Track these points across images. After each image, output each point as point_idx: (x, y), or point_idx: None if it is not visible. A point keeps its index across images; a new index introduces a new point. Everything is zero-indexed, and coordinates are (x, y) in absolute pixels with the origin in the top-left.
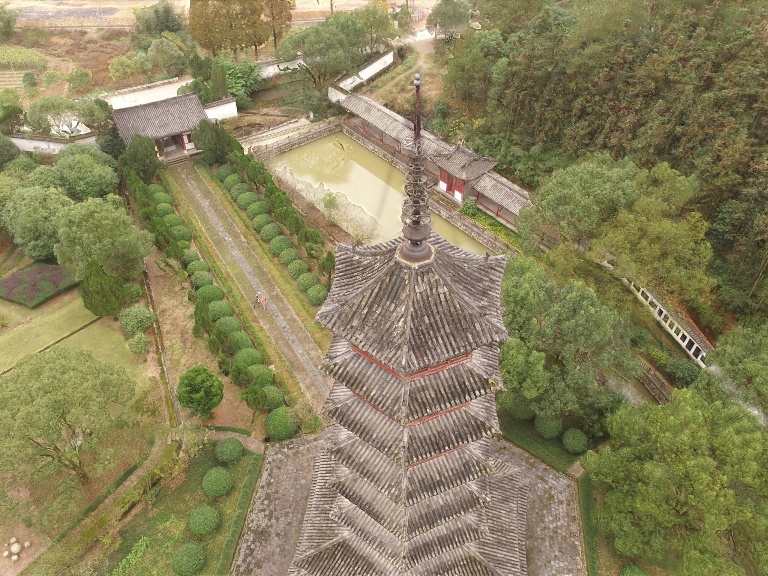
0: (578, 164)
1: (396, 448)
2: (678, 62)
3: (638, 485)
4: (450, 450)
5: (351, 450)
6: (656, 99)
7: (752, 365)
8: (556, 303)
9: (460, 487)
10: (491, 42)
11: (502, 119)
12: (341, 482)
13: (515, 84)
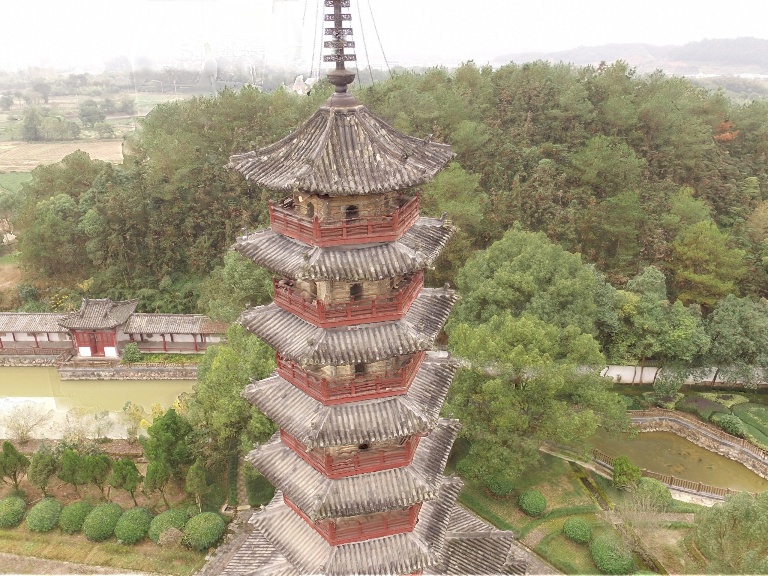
0: None
1: (408, 341)
2: None
3: (492, 405)
4: (420, 362)
5: (334, 426)
6: (255, 196)
7: (480, 289)
8: None
9: None
10: (64, 204)
11: (114, 269)
12: (324, 504)
13: (116, 228)
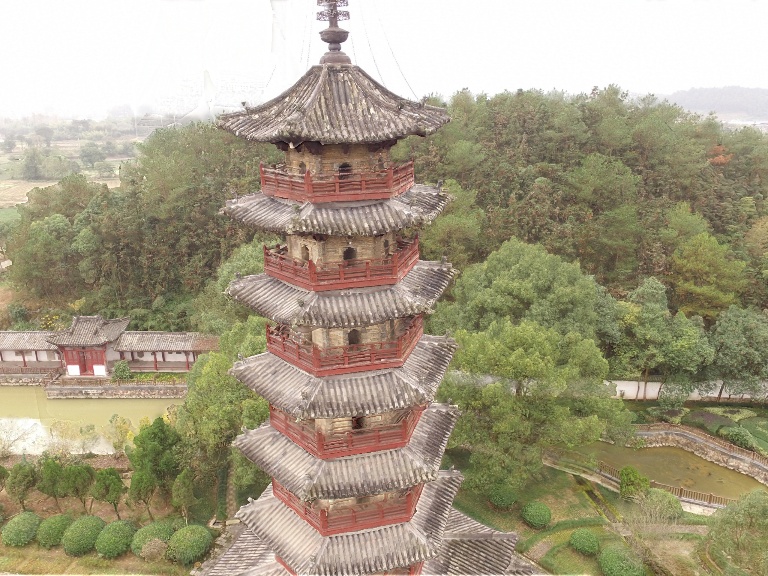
0: (231, 262)
1: (404, 304)
2: (254, 182)
3: (493, 409)
4: (417, 338)
5: (325, 398)
6: None
7: (478, 297)
8: None
9: (425, 415)
10: (58, 224)
11: (106, 289)
12: (315, 485)
13: (110, 246)
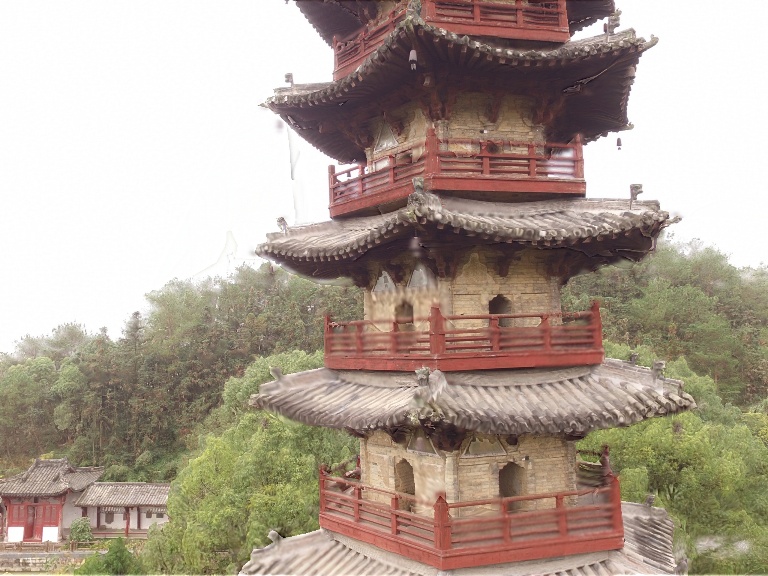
0: None
1: None
2: (273, 319)
3: None
4: None
5: None
6: (267, 354)
7: None
8: (349, 436)
9: None
10: (41, 364)
11: (82, 440)
12: (436, 403)
13: (97, 385)
